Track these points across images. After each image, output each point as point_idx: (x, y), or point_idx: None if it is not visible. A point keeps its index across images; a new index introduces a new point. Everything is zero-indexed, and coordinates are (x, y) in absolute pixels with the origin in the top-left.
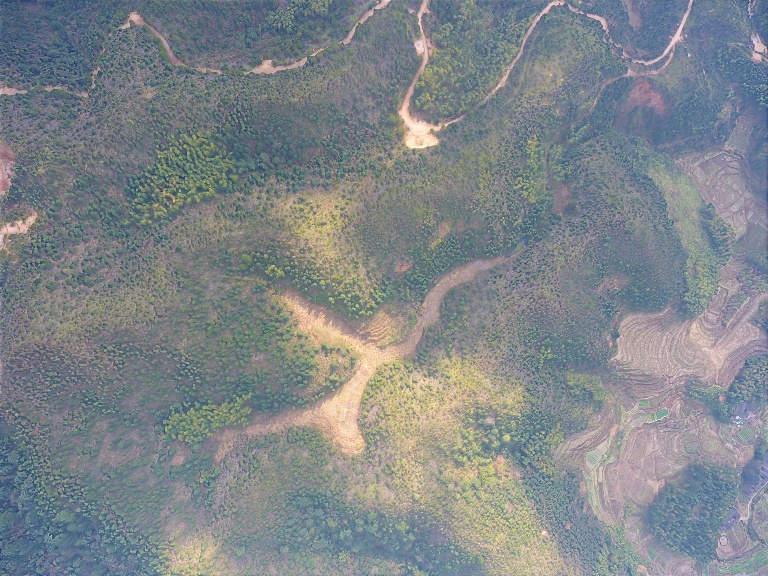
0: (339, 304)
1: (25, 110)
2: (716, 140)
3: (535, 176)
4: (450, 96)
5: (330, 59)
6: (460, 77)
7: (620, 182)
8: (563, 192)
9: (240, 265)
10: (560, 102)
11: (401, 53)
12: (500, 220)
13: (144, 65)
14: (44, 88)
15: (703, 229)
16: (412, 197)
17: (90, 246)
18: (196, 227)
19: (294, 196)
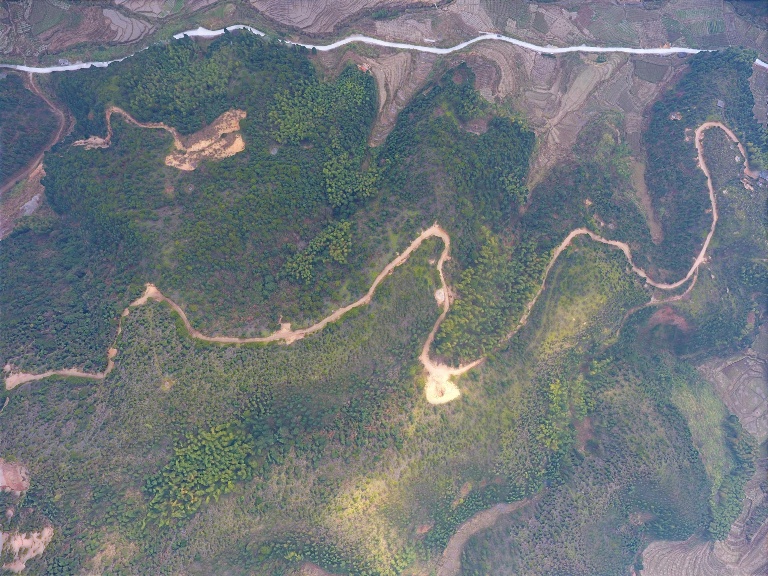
0: (359, 575)
1: (41, 415)
2: (739, 349)
3: (557, 417)
4: (471, 341)
5: (350, 326)
6: (481, 321)
7: (644, 418)
8: (585, 424)
9: (259, 557)
10: (583, 341)
11: (422, 309)
12: (523, 475)
13: (162, 350)
14: (59, 373)
15: (727, 446)
16: (434, 470)
17: (107, 555)
18: (215, 529)
19: (314, 474)
